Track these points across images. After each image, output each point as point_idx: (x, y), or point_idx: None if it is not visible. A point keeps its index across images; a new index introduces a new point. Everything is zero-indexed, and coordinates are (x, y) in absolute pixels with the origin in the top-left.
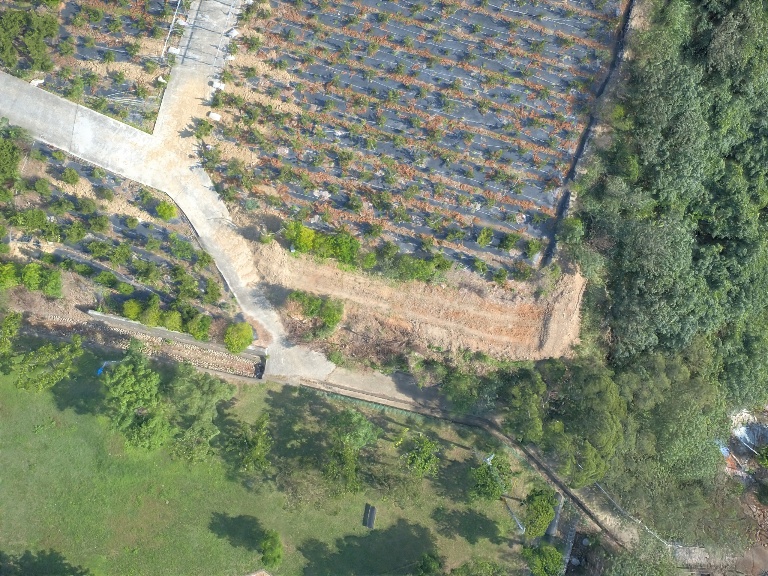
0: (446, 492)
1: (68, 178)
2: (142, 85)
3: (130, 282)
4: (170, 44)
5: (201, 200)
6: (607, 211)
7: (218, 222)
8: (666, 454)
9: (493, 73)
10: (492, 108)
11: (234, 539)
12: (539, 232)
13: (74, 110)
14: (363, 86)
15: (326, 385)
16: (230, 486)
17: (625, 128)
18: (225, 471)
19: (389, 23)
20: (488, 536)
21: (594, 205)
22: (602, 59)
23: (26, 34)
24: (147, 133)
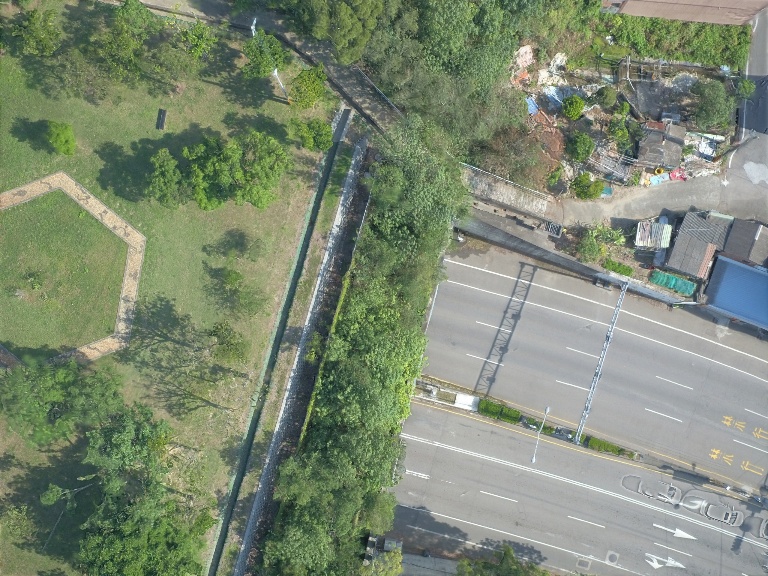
0: (235, 97)
1: None
2: None
3: None
4: None
5: None
6: None
7: None
8: (435, 41)
9: None
10: None
11: (33, 142)
12: None
13: None
14: None
15: (122, 3)
16: (29, 93)
17: None
18: (24, 79)
19: None
20: (276, 138)
21: None
22: None
23: None
24: None
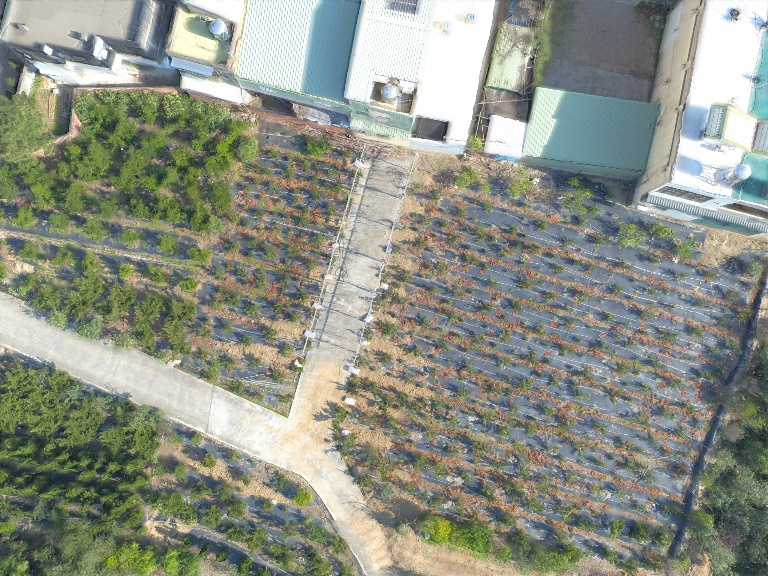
0: None
1: (208, 466)
2: (278, 368)
3: (265, 563)
4: (306, 327)
5: (336, 484)
6: (736, 502)
7: (353, 506)
8: None
9: (624, 360)
10: (623, 396)
11: None
12: (668, 520)
13: (211, 391)
14: (496, 372)
15: None
16: None
17: (758, 428)
18: None
19: (522, 309)
20: None
21: (724, 498)
22: (734, 352)
23: (166, 319)
24: (283, 416)
